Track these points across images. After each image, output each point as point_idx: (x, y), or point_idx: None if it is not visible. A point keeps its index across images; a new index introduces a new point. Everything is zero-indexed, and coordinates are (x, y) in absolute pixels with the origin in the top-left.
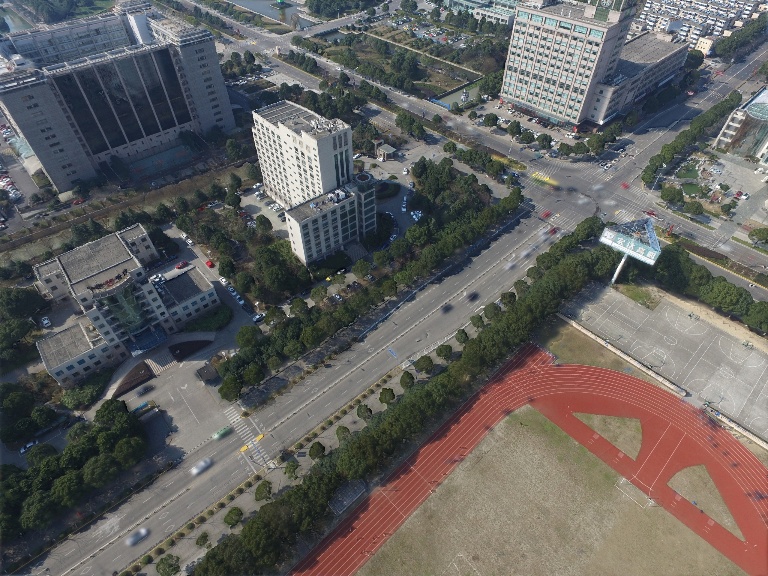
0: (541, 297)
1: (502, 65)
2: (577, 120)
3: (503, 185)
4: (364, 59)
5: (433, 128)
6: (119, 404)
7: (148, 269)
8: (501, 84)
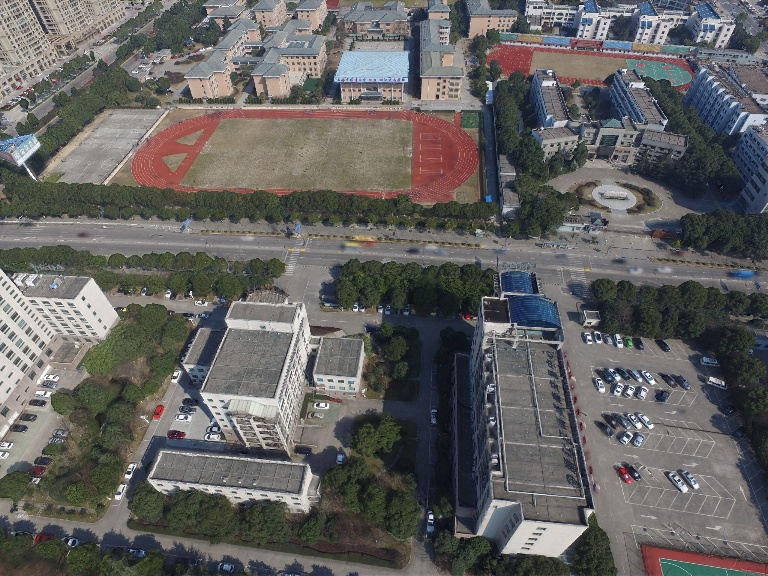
0: (91, 186)
1: None
2: None
3: None
4: None
5: None
6: (338, 285)
7: None
8: None
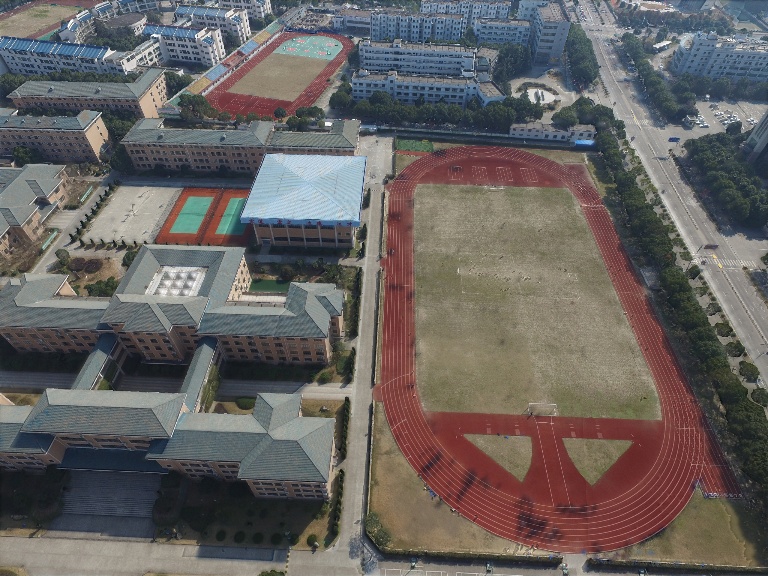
0: None
1: None
2: None
3: None
4: None
5: None
6: None
7: None
8: None
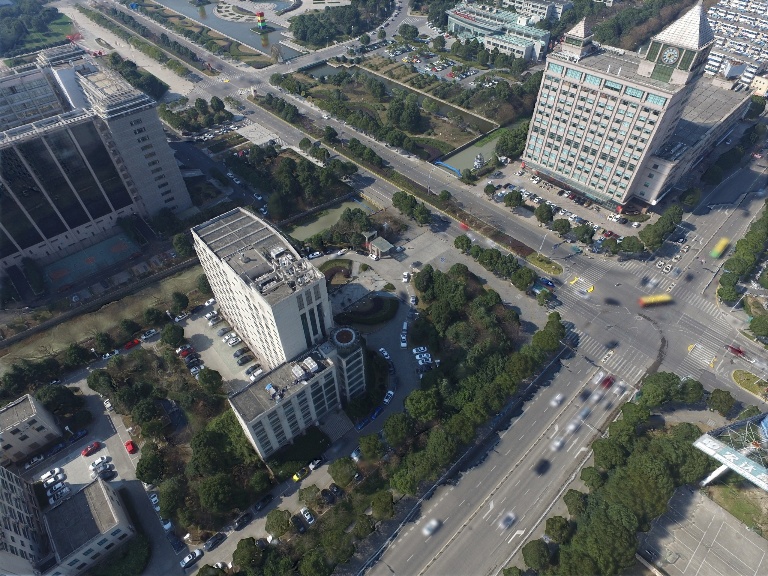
0: (611, 543)
1: (521, 112)
2: (623, 199)
3: (534, 300)
4: (356, 103)
5: (440, 206)
6: None
7: (42, 458)
8: (523, 144)
